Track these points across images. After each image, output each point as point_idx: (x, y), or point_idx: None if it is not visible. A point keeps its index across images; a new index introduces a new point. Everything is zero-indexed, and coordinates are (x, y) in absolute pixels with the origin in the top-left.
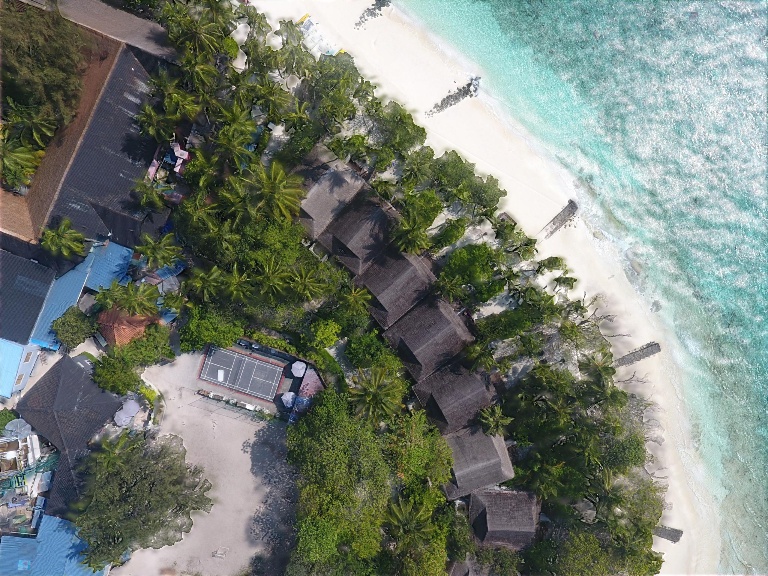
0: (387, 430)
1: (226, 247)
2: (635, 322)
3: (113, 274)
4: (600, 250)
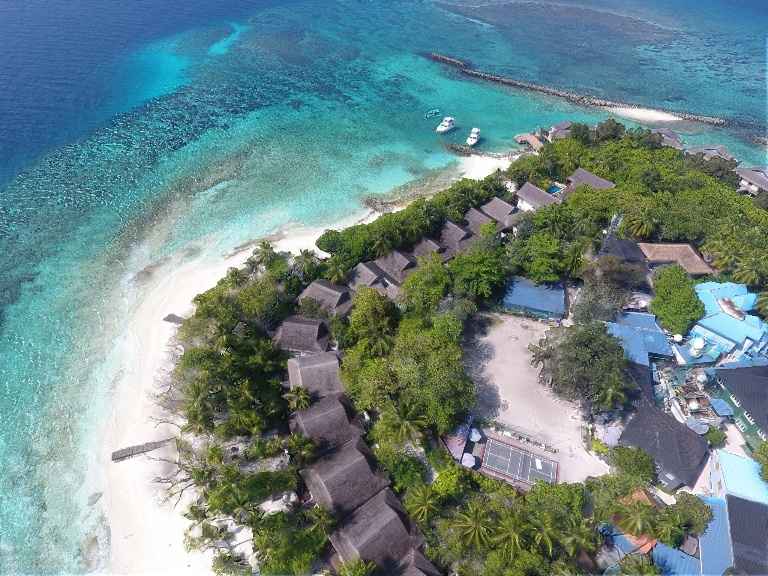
0: (392, 396)
1: (566, 569)
2: (125, 483)
3: (676, 571)
4: (127, 572)
